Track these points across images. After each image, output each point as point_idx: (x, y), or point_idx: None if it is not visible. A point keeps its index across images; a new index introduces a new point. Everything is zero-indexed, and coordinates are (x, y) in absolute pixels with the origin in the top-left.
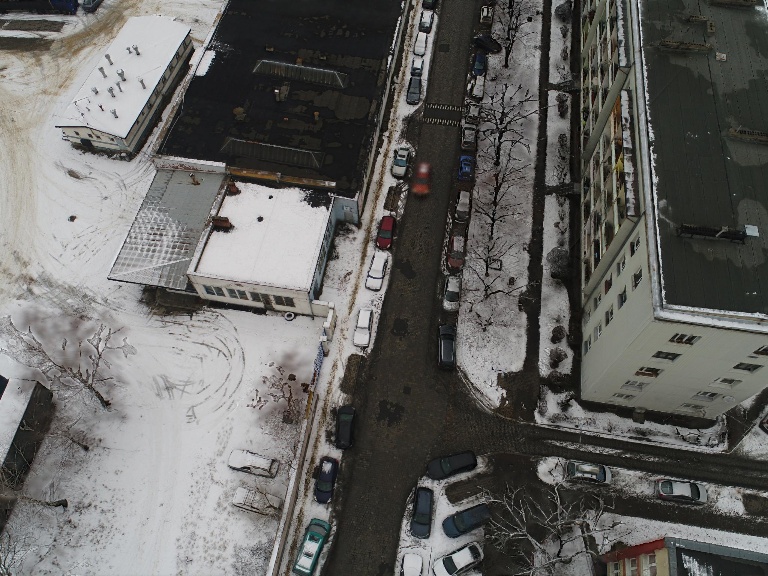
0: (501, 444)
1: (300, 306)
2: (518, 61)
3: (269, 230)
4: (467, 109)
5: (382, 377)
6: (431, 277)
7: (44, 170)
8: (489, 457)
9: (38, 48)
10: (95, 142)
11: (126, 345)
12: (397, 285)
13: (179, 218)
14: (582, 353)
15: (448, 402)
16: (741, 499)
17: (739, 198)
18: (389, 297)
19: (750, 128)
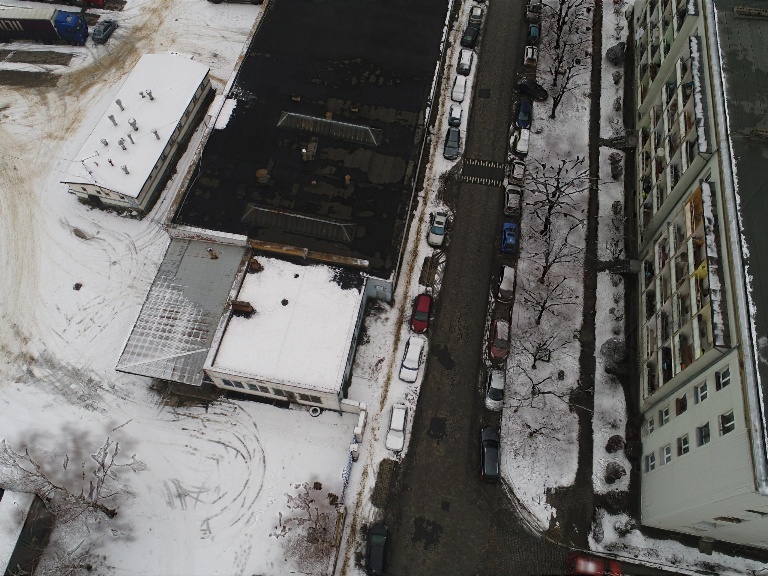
0: (551, 575)
1: (327, 403)
2: (566, 111)
3: (295, 316)
4: (510, 166)
5: (418, 488)
6: (471, 367)
7: (48, 228)
8: None
9: (44, 84)
10: (104, 198)
11: (135, 462)
12: (434, 376)
13: (195, 299)
14: (642, 468)
15: (491, 521)
16: None
17: None
18: (425, 390)
19: None
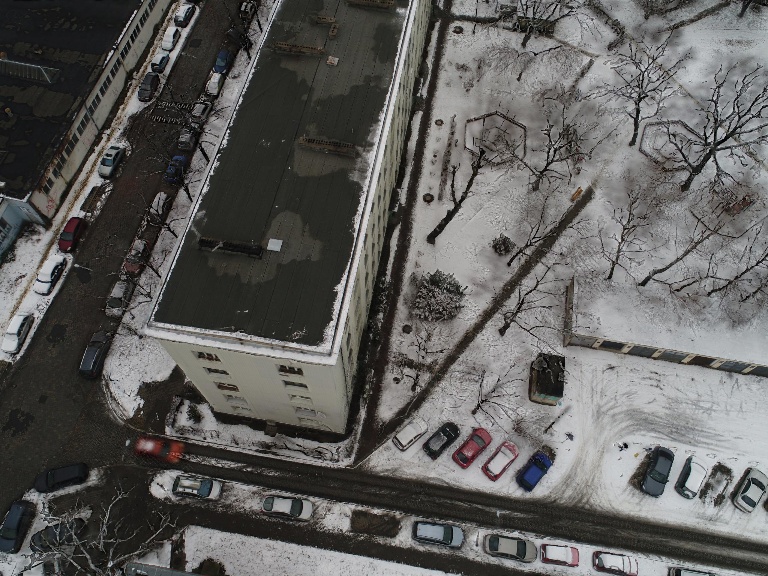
0: None
1: None
2: None
3: None
4: None
5: (22, 385)
6: (106, 281)
7: None
8: (105, 469)
9: None
10: None
11: None
12: (68, 289)
13: None
14: None
15: (81, 412)
16: (350, 516)
17: (279, 210)
18: (56, 302)
19: (328, 137)
